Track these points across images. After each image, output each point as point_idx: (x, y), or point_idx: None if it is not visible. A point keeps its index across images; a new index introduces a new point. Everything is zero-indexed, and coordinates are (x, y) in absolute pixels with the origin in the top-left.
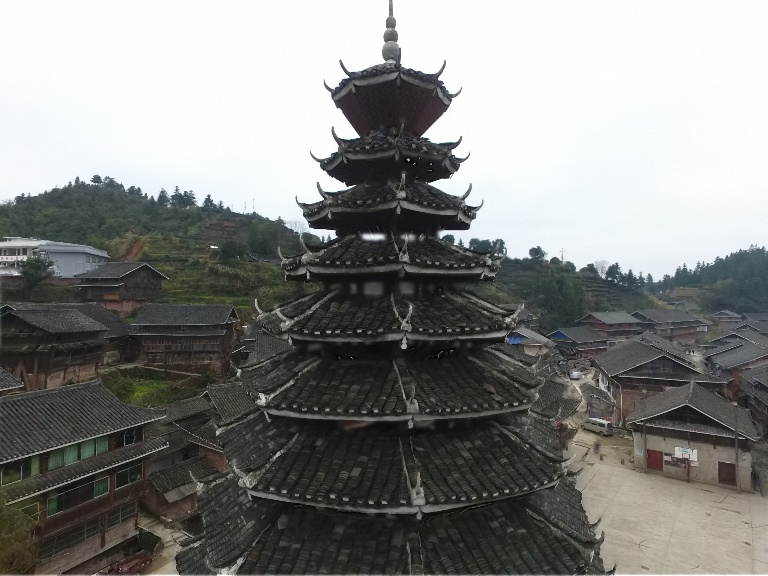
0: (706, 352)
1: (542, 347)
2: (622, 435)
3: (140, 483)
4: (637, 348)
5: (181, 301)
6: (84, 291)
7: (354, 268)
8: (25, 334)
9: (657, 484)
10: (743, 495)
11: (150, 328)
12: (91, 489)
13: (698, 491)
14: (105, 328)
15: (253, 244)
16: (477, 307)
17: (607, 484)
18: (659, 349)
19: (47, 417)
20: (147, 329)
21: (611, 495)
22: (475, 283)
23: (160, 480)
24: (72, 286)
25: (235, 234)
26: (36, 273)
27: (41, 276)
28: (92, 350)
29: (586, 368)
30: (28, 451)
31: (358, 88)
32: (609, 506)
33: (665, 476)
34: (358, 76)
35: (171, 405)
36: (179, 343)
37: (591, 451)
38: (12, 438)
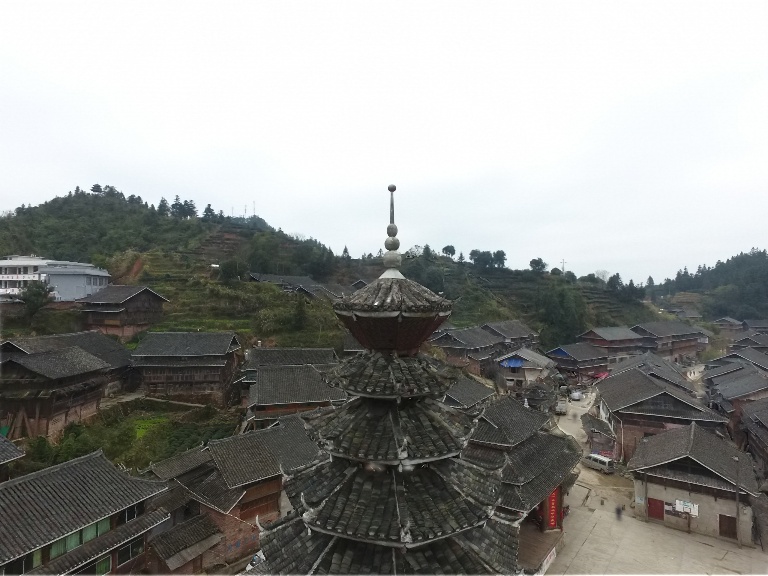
0: (707, 373)
1: (543, 369)
2: (623, 473)
3: (142, 556)
4: (638, 379)
5: (182, 325)
6: (85, 316)
7: (356, 538)
8: (26, 380)
9: (658, 536)
10: (744, 550)
11: (151, 359)
12: (93, 571)
13: (699, 545)
14: (106, 365)
15: (254, 264)
16: (479, 558)
17: (608, 536)
18: (660, 377)
19: (49, 502)
20: (148, 360)
21: (612, 550)
22: (476, 298)
23: (162, 545)
24: (73, 309)
25: (236, 254)
26: (37, 300)
27: (42, 302)
28: (93, 389)
29: (587, 391)
30: (30, 547)
31: (359, 318)
32: (610, 564)
33: (666, 526)
34: (359, 308)
35: (172, 459)
36: (180, 373)
37: (592, 493)
38: (14, 532)
